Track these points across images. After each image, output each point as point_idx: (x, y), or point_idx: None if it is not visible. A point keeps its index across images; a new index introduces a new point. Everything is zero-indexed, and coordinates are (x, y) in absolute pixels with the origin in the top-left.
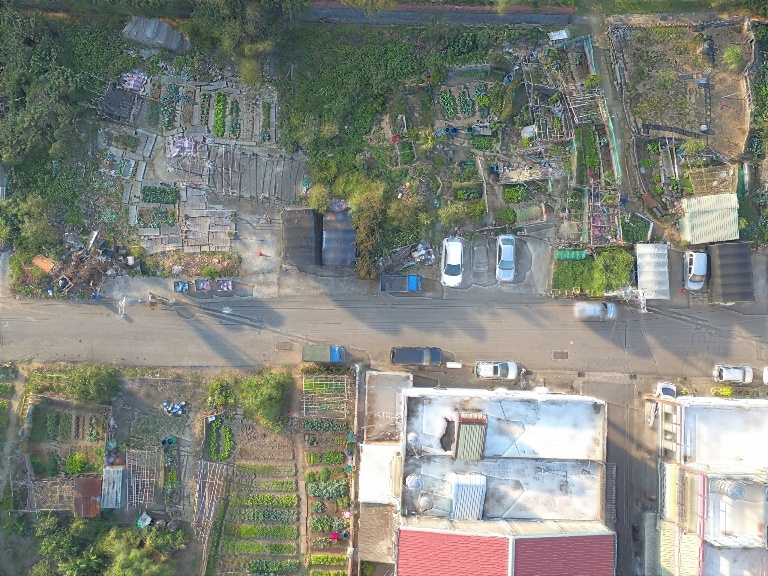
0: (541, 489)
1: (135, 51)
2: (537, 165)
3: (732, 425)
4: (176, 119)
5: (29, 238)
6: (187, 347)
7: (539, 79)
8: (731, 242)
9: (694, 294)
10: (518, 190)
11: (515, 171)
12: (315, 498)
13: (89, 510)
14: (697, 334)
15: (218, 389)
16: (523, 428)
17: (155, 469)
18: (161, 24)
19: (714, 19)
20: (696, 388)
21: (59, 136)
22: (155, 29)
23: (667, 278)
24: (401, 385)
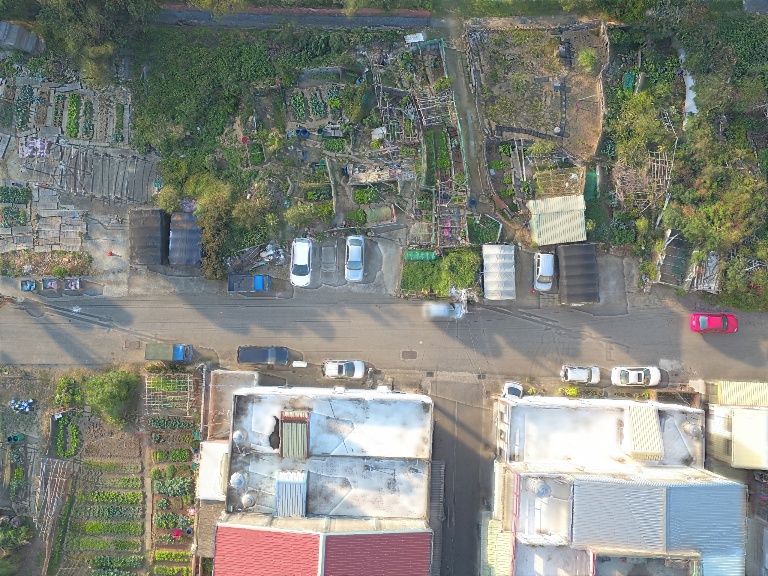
0: (369, 487)
1: None
2: (387, 166)
3: (561, 424)
4: (30, 120)
5: None
6: (36, 345)
7: (393, 81)
8: (582, 243)
9: (545, 295)
10: (368, 191)
11: (365, 172)
12: (161, 495)
13: None
14: (547, 334)
15: (65, 387)
16: (352, 426)
17: None
18: (12, 26)
19: (573, 22)
20: (544, 388)
21: None
22: (6, 31)
23: (513, 279)
24: (249, 384)
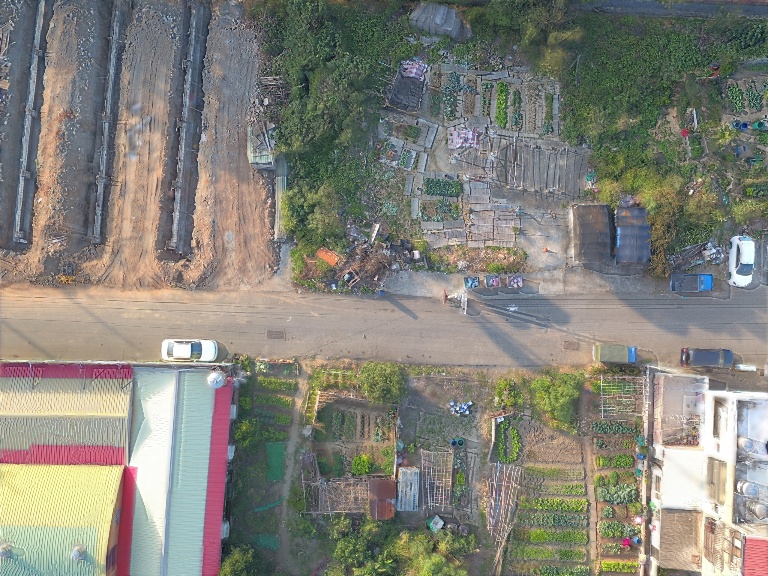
0: None
1: (415, 38)
2: None
3: None
4: (457, 109)
5: (315, 230)
6: (473, 345)
7: None
8: None
9: None
10: None
11: None
12: (604, 503)
13: (384, 512)
14: None
15: (507, 389)
16: None
17: (451, 471)
18: (450, 10)
19: None
20: None
21: (346, 125)
22: (444, 15)
23: None
24: (688, 387)
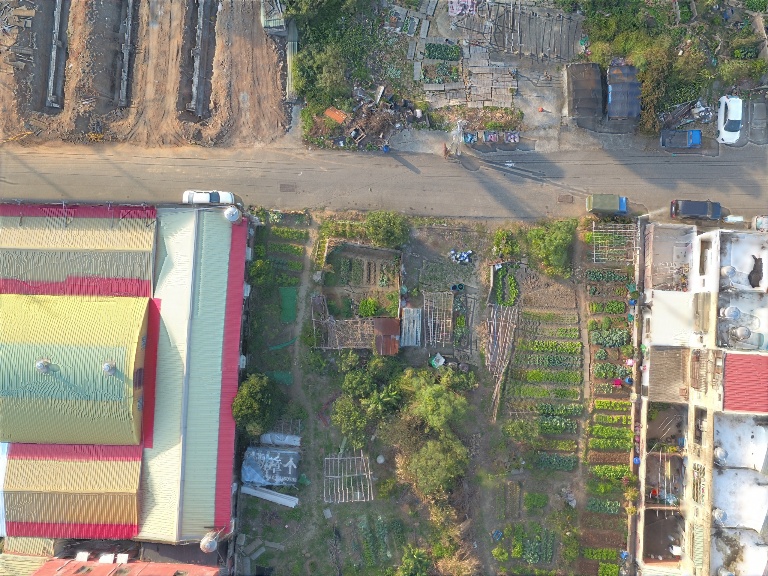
0: None
1: None
2: None
3: None
4: None
5: (324, 90)
6: (473, 198)
7: None
8: None
9: None
10: None
11: None
12: (597, 346)
13: (388, 348)
14: None
15: (504, 238)
16: None
17: (451, 310)
18: None
19: None
20: None
21: None
22: None
23: None
24: (678, 239)
